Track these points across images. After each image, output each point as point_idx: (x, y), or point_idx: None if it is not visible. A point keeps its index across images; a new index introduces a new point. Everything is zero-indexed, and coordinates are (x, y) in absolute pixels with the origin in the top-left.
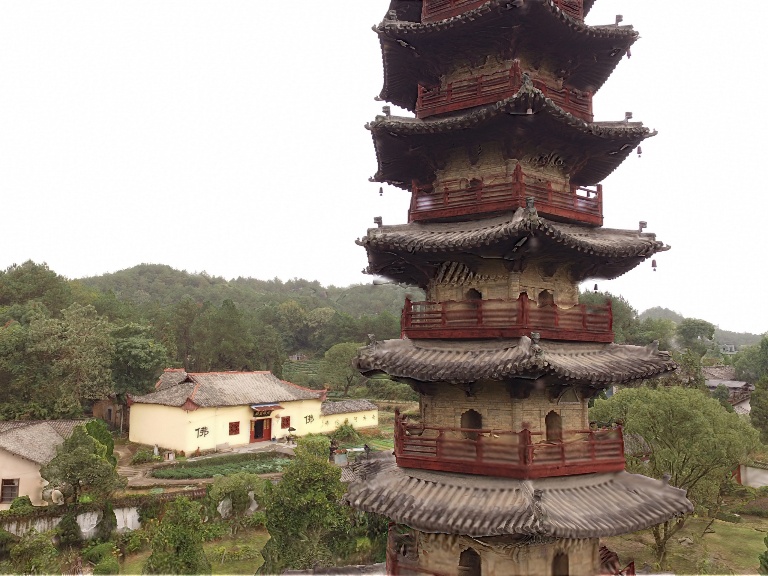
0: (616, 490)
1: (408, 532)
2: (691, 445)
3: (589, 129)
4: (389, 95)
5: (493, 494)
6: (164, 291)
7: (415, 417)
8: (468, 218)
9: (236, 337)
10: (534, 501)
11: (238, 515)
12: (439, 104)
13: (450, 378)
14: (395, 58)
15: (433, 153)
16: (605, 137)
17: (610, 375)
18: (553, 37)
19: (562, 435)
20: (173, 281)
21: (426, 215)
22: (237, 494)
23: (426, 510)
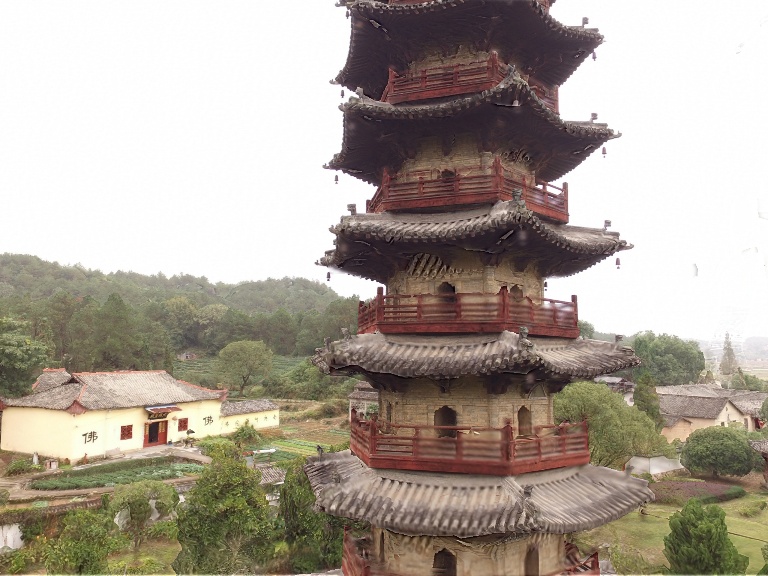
0: (583, 483)
1: (364, 535)
2: (601, 437)
3: (564, 126)
4: (347, 79)
5: (474, 492)
6: (31, 284)
7: (315, 416)
8: (443, 209)
9: (123, 334)
10: (524, 498)
11: (138, 526)
12: (412, 90)
13: (435, 374)
14: (363, 39)
15: (405, 141)
16: (576, 135)
17: (586, 370)
18: (528, 32)
19: (532, 430)
20: (42, 273)
21: (399, 205)
22: (137, 503)
23: (407, 512)
